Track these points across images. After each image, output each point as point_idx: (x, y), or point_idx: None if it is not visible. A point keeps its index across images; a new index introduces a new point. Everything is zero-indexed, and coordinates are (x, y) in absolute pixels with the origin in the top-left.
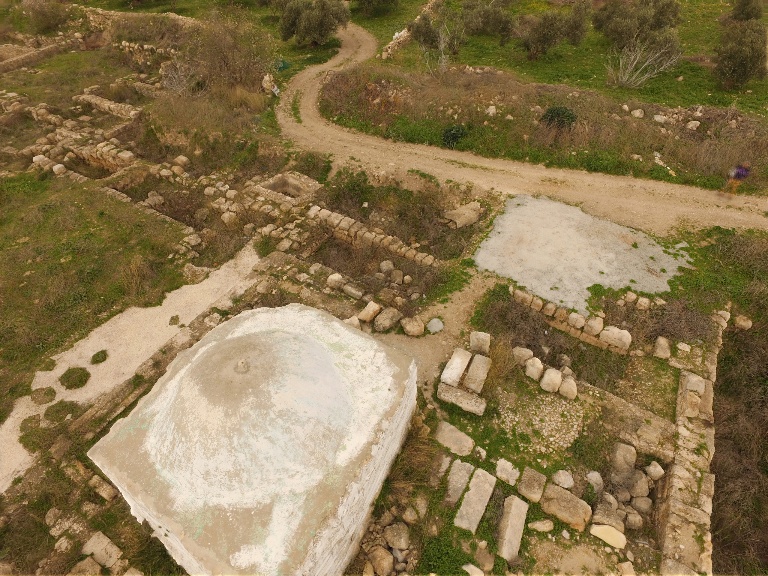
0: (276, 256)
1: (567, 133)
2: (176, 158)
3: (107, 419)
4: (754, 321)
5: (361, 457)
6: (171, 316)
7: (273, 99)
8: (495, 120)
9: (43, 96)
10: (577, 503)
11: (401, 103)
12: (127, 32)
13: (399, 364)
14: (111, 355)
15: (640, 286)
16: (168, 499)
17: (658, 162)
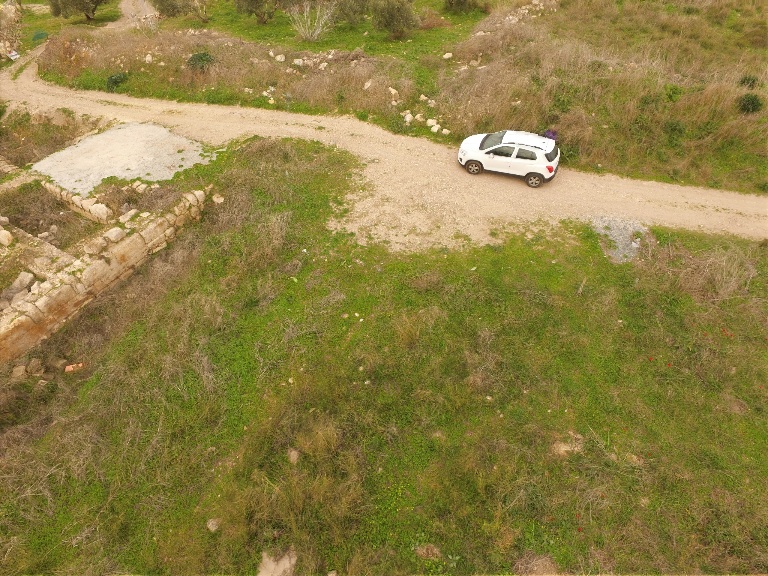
0: None
1: (200, 74)
2: None
3: None
4: None
5: None
6: None
7: (6, 63)
8: (150, 66)
9: None
10: None
11: (88, 57)
12: None
13: None
14: None
15: (150, 177)
16: None
17: (263, 93)
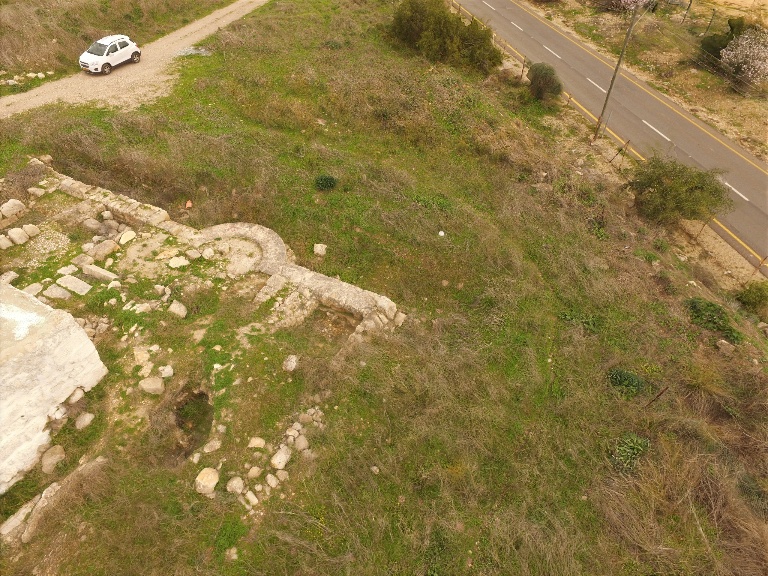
0: None
1: None
2: None
3: None
4: (49, 154)
5: None
6: None
7: None
8: None
9: None
10: (104, 243)
11: None
12: None
13: None
14: None
15: None
16: None
17: None
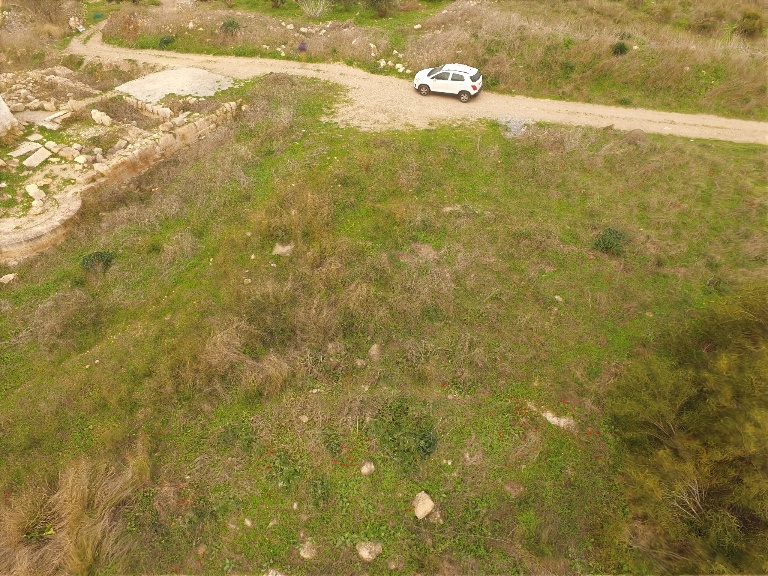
0: (11, 94)
1: (230, 36)
2: None
3: None
4: None
5: None
6: None
7: (76, 33)
8: (192, 31)
9: None
10: None
11: (143, 26)
12: (7, 4)
13: None
14: None
15: (198, 94)
16: None
17: (277, 49)
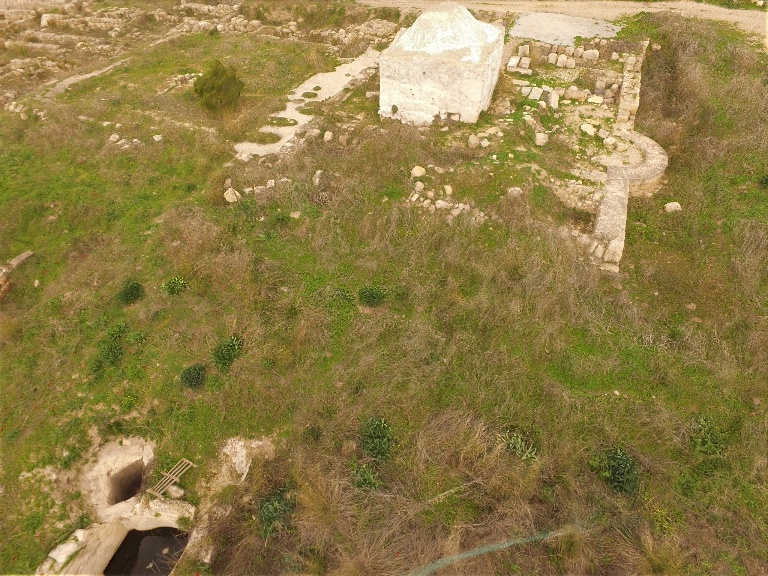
0: None
1: None
2: (289, 23)
3: (341, 101)
4: (662, 46)
5: (496, 42)
6: (345, 74)
7: None
8: None
9: (150, 8)
10: (580, 92)
11: None
12: None
13: (499, 26)
14: (323, 87)
15: (601, 36)
16: (427, 54)
17: None
